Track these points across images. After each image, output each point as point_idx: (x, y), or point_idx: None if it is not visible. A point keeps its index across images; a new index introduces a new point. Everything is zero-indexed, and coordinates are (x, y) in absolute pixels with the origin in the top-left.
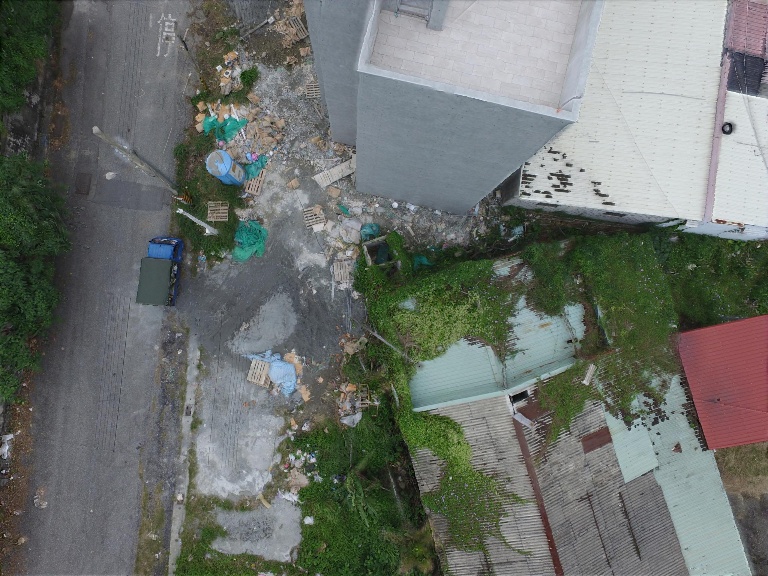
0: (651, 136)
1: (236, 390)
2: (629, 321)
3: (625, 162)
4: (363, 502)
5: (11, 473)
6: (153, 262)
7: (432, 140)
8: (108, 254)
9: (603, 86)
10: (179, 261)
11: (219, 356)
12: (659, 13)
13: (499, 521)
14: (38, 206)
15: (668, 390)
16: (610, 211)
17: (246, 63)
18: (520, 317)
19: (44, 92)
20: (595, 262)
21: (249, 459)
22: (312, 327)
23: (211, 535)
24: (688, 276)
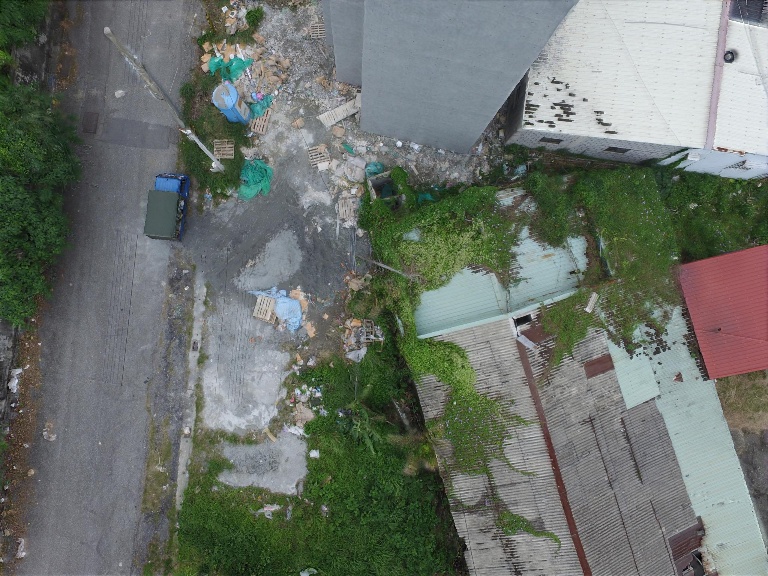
0: (653, 65)
1: (242, 326)
2: (631, 252)
3: (627, 91)
4: (368, 427)
5: (20, 406)
6: (160, 194)
7: (438, 45)
8: (115, 192)
9: (606, 16)
10: (186, 197)
11: (225, 293)
12: None
13: (503, 443)
14: (47, 132)
15: (670, 321)
16: (612, 145)
17: (251, 4)
18: (523, 247)
19: (51, 33)
20: (597, 193)
21: (255, 394)
22: (317, 264)
23: (218, 467)
24: (689, 214)
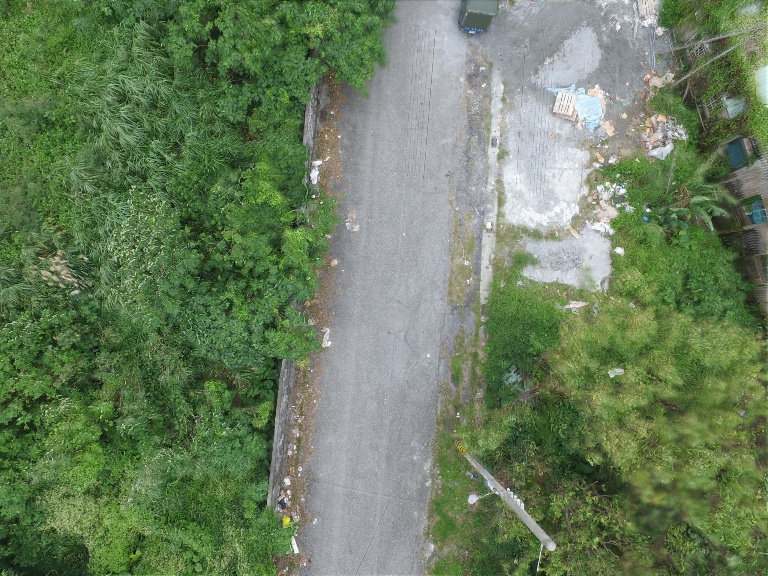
0: None
1: (542, 123)
2: None
3: None
4: None
5: (321, 198)
6: None
7: None
8: None
9: None
10: None
11: (523, 90)
12: None
13: None
14: None
15: None
16: None
17: None
18: None
19: None
20: None
21: (557, 190)
22: (615, 64)
23: (525, 259)
24: None
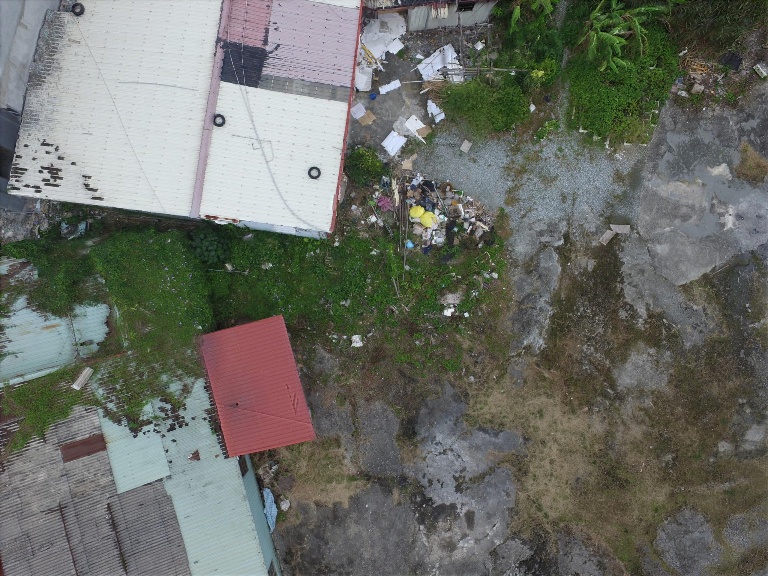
0: (143, 128)
1: None
2: (144, 322)
3: (116, 155)
4: None
5: None
6: None
7: None
8: None
9: (98, 76)
10: None
11: None
12: (158, 1)
13: None
14: None
15: (189, 394)
16: None
17: None
18: (16, 318)
19: None
20: (106, 260)
21: None
22: None
23: None
24: (260, 275)
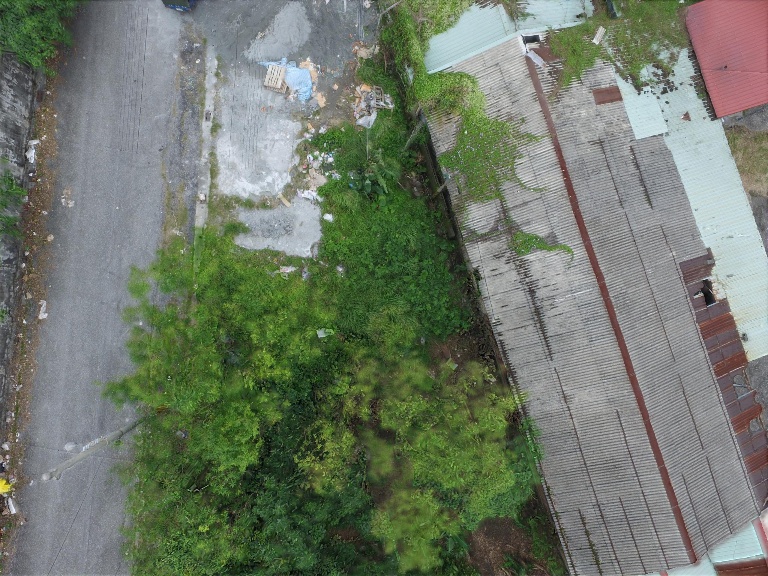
0: None
1: (254, 96)
2: None
3: None
4: (381, 160)
5: (38, 175)
6: None
7: None
8: None
9: None
10: None
11: (236, 65)
12: None
13: (514, 163)
14: None
15: (676, 62)
16: None
17: None
18: None
19: None
20: None
21: (268, 161)
22: (326, 37)
23: (234, 228)
24: None
